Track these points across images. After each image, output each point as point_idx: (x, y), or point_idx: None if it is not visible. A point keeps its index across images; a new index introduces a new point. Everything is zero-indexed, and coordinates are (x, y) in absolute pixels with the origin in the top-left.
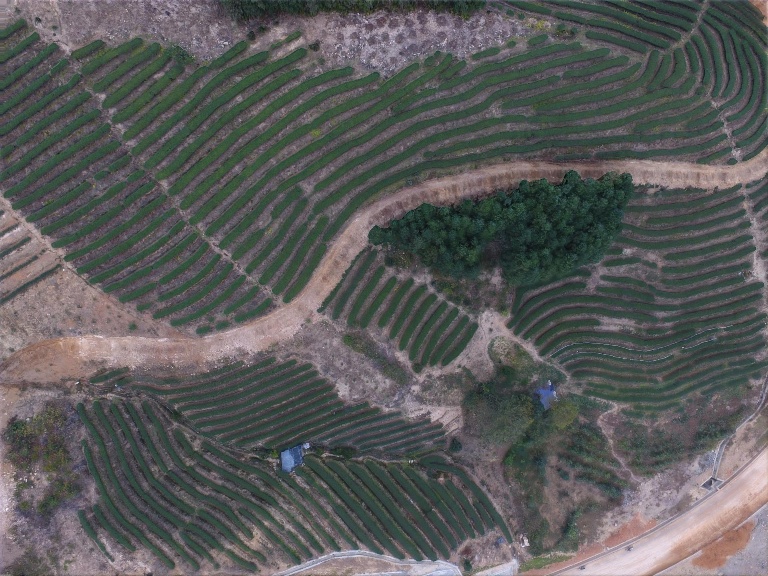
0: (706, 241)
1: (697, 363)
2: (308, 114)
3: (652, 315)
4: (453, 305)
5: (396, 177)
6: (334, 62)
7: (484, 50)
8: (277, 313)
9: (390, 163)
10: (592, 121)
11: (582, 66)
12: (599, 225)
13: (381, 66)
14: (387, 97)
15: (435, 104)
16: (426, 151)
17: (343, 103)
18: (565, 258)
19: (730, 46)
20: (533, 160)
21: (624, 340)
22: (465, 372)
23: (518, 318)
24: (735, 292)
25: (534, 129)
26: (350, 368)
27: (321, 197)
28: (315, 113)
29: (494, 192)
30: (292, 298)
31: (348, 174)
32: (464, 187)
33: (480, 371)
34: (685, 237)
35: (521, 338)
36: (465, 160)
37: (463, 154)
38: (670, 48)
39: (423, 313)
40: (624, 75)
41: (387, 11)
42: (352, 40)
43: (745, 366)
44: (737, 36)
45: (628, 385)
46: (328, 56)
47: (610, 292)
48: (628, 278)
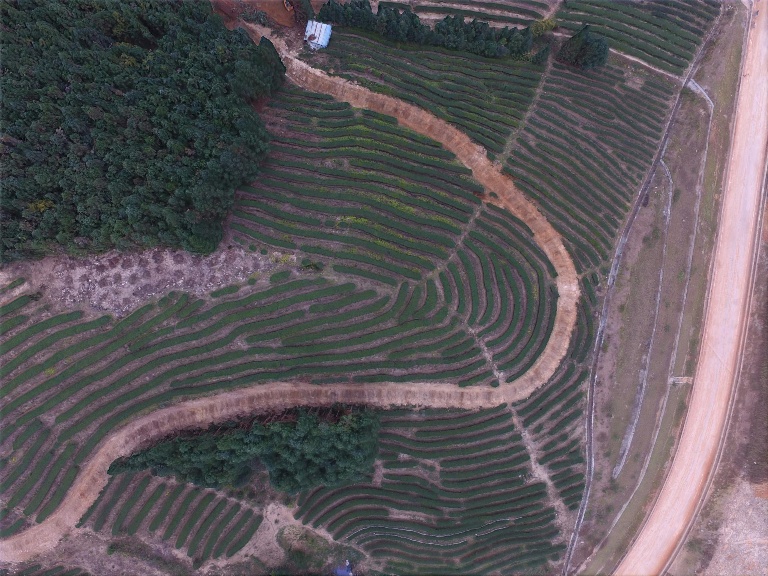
0: (479, 451)
1: (494, 546)
2: (40, 354)
3: (439, 508)
4: (235, 500)
5: (144, 405)
6: (63, 305)
7: (224, 287)
8: (35, 528)
9: (134, 394)
10: (345, 349)
11: (329, 299)
12: (339, 464)
13: (112, 308)
14: (121, 337)
15: (172, 342)
16: (174, 379)
17: (75, 344)
18: (321, 481)
19: (491, 270)
20: (291, 382)
21: (416, 528)
22: (253, 560)
23: (305, 510)
24: (517, 492)
25: (285, 357)
26: (124, 568)
27: (66, 425)
28: (47, 353)
29: (254, 410)
30: (47, 516)
31: (92, 404)
32: (221, 407)
33: (270, 558)
34: (458, 446)
35: (312, 525)
36: (215, 388)
37: (214, 380)
38: (424, 277)
39: (199, 513)
40: (371, 310)
41: (121, 250)
42: (81, 283)
43: (543, 548)
44: (501, 258)
45: (427, 565)
46: (55, 300)
47: (394, 489)
48: (410, 477)
